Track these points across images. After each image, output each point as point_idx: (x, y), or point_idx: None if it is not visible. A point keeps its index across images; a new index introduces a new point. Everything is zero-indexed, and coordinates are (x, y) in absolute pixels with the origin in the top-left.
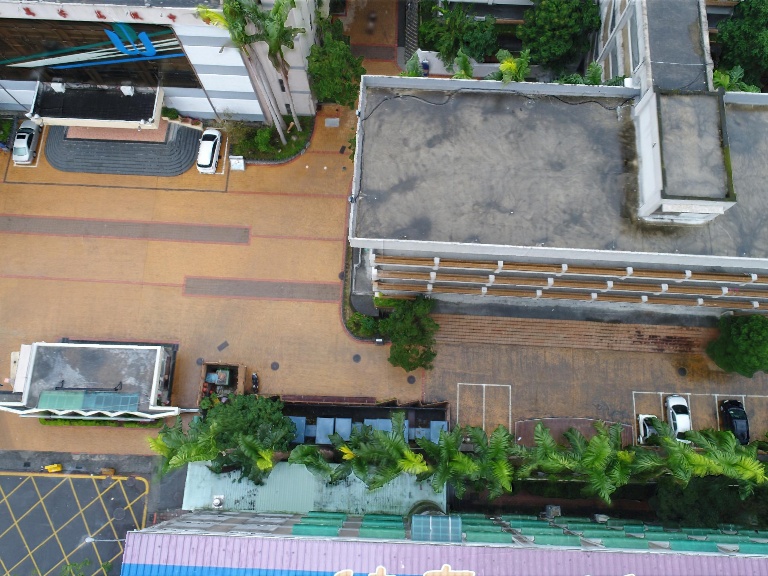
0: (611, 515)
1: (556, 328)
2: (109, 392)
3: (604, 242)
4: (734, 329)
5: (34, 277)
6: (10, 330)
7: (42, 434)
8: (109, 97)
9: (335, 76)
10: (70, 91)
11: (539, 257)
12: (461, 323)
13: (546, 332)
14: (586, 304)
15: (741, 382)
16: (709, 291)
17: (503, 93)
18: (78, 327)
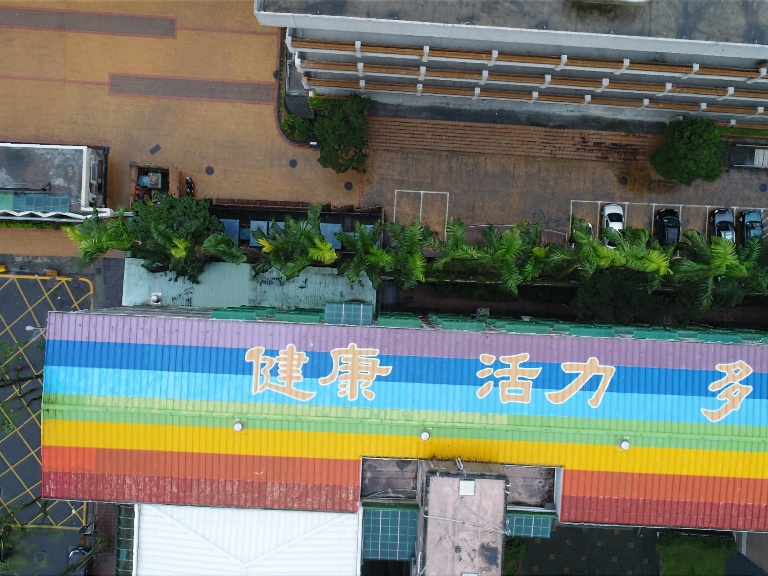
0: (538, 317)
1: (498, 133)
2: (39, 193)
3: (534, 22)
4: (677, 133)
5: None
6: None
7: None
8: None
9: None
10: None
11: (470, 44)
12: (400, 127)
13: (488, 138)
14: (532, 108)
15: (681, 192)
16: (651, 87)
17: None
18: (2, 128)
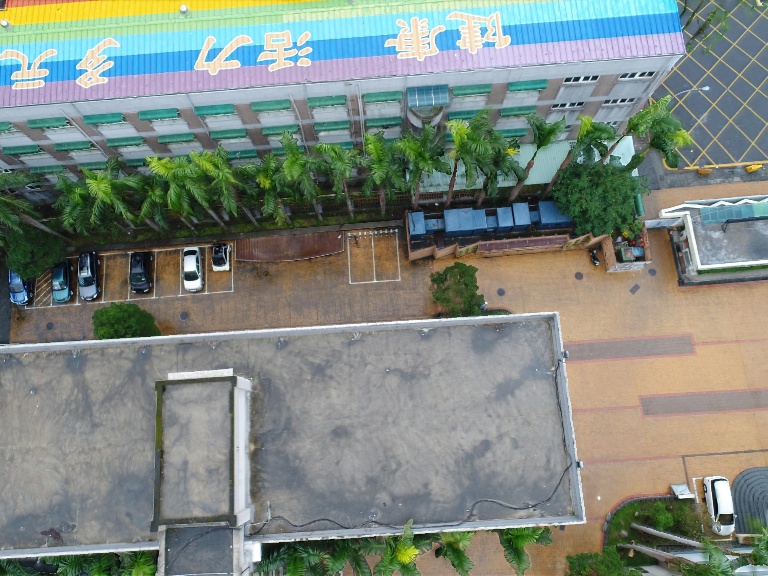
0: None
1: None
2: None
3: (289, 348)
4: None
5: None
6: None
7: None
8: None
9: None
10: None
11: None
12: None
13: None
14: None
15: None
16: None
17: None
18: None
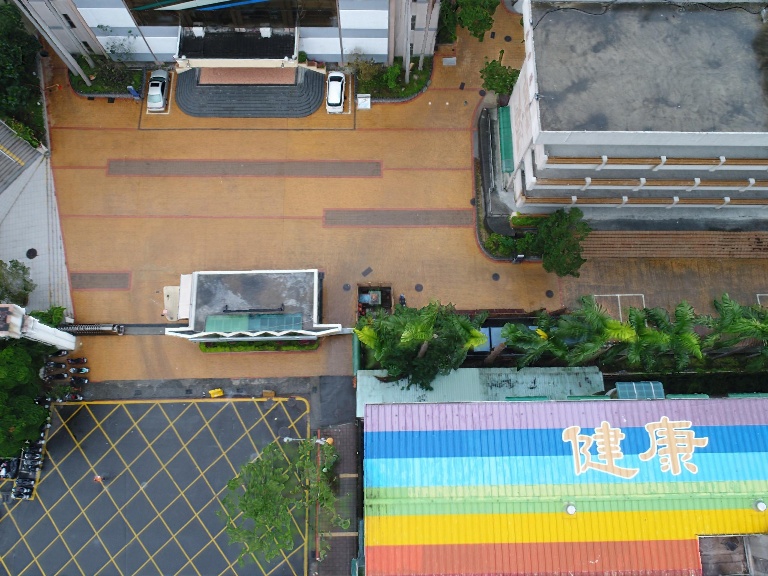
0: None
1: (681, 239)
2: (272, 314)
3: (767, 128)
4: None
5: (178, 216)
6: (160, 267)
7: (201, 362)
8: (247, 39)
9: (476, 5)
10: (209, 35)
11: (693, 154)
12: (593, 239)
13: (672, 243)
14: (707, 216)
15: None
16: None
17: (656, 2)
18: (225, 261)
